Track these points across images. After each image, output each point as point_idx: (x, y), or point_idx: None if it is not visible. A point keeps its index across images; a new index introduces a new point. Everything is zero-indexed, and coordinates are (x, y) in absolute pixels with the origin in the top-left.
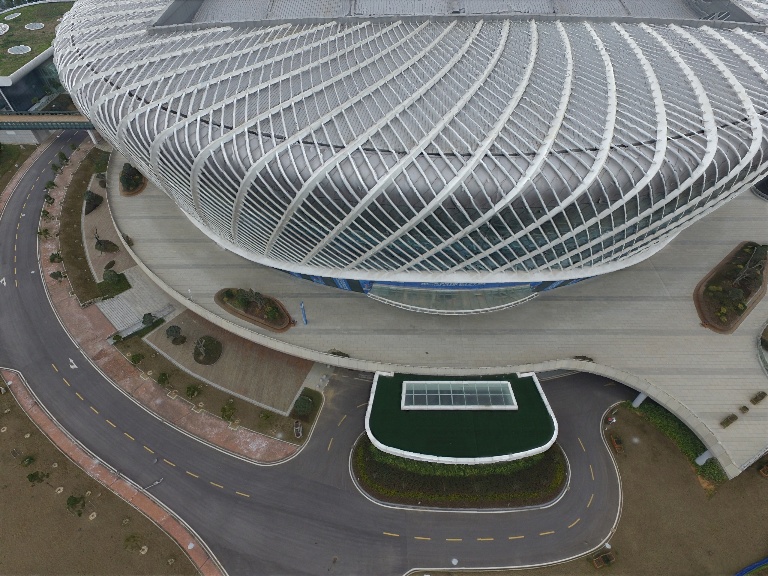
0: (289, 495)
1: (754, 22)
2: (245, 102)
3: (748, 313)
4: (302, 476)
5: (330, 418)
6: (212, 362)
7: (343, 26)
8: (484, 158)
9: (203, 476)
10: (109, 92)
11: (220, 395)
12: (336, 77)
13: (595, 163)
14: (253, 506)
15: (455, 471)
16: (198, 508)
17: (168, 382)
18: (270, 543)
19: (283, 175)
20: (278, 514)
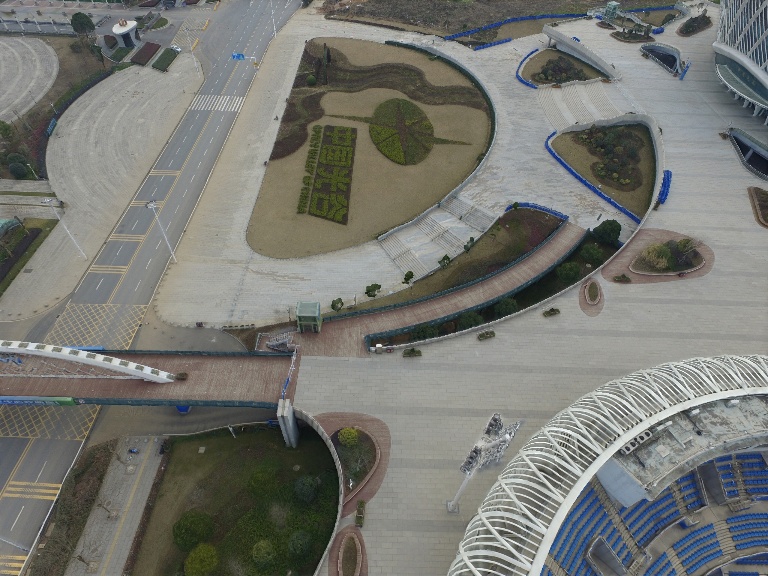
0: None
1: None
2: None
3: None
4: None
5: None
6: None
7: None
8: None
9: None
10: None
11: None
12: None
13: None
14: None
15: None
16: None
17: None
18: None
19: None
20: None
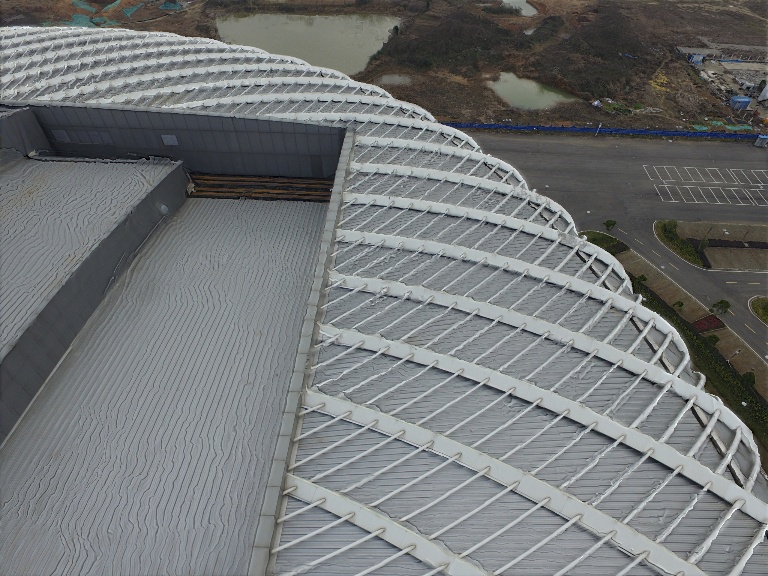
0: None
1: None
2: (226, 52)
3: None
4: None
5: None
6: None
7: None
8: None
9: None
10: (372, 89)
11: None
12: (129, 51)
13: None
14: None
15: None
16: None
17: None
18: None
19: None
20: None
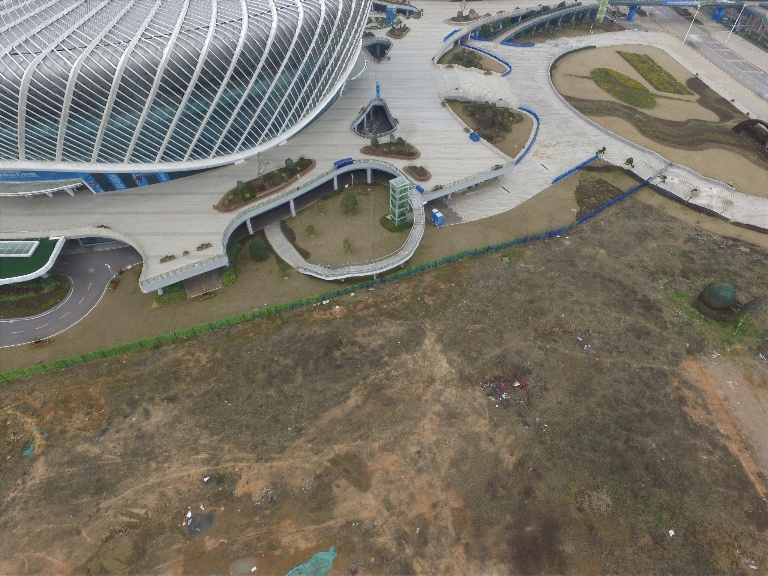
0: None
1: None
2: None
3: (256, 201)
4: None
5: None
6: None
7: None
8: None
9: None
10: None
11: None
12: None
13: None
14: None
15: None
16: None
17: None
18: None
19: None
20: None
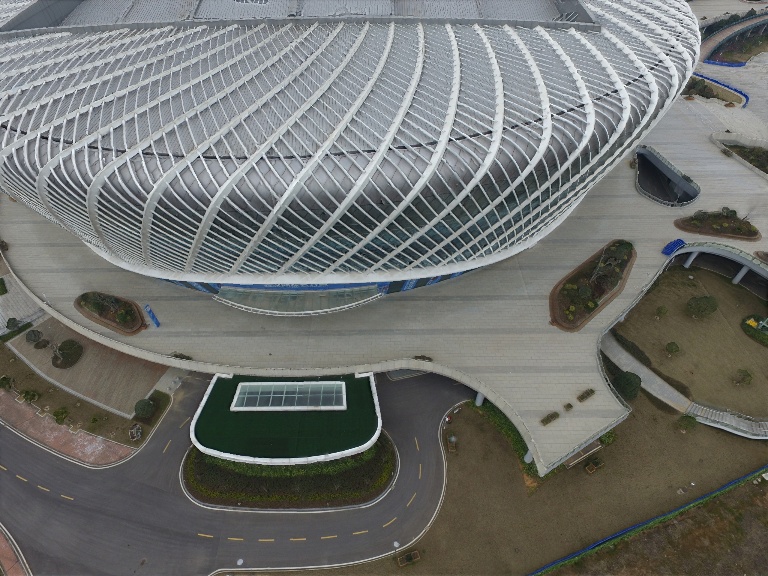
0: (113, 498)
1: (591, 22)
2: (46, 107)
3: (599, 311)
4: (131, 478)
5: (173, 420)
6: (69, 366)
7: (178, 30)
8: (259, 161)
9: (32, 480)
10: None
11: (69, 399)
12: (143, 82)
13: (369, 165)
14: (75, 509)
15: (282, 472)
16: (19, 512)
17: (9, 386)
18: (83, 546)
19: (67, 180)
20: (98, 517)
